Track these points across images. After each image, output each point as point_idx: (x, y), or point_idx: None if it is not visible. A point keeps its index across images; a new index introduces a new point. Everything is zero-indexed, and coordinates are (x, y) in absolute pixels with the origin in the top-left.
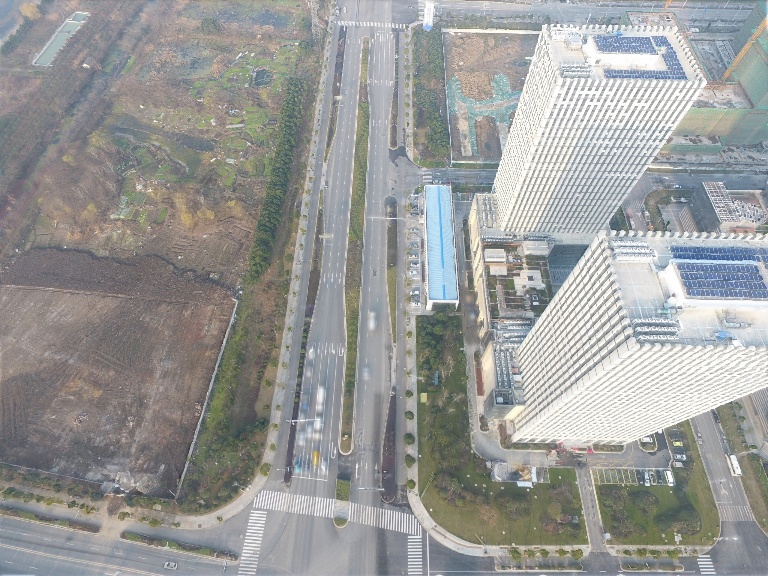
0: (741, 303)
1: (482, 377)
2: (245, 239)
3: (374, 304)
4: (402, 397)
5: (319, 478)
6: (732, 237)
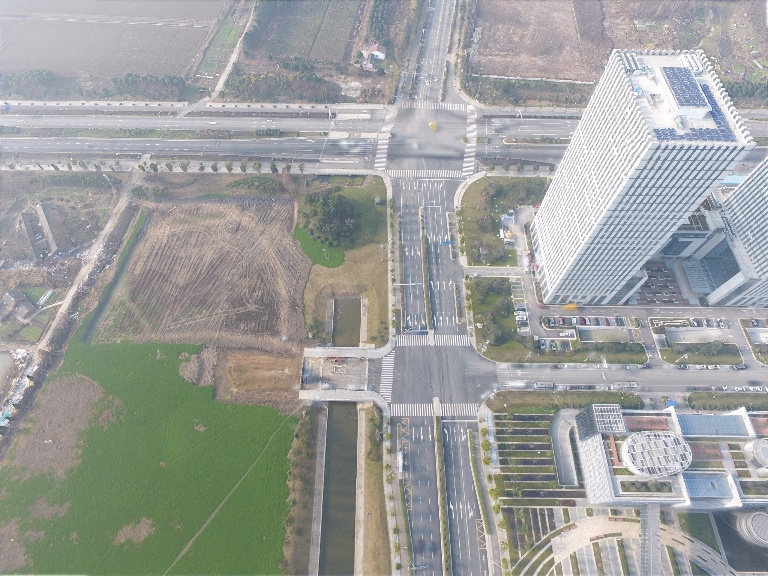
0: (668, 93)
1: None
2: None
3: None
4: (548, 169)
5: (487, 130)
6: (734, 114)
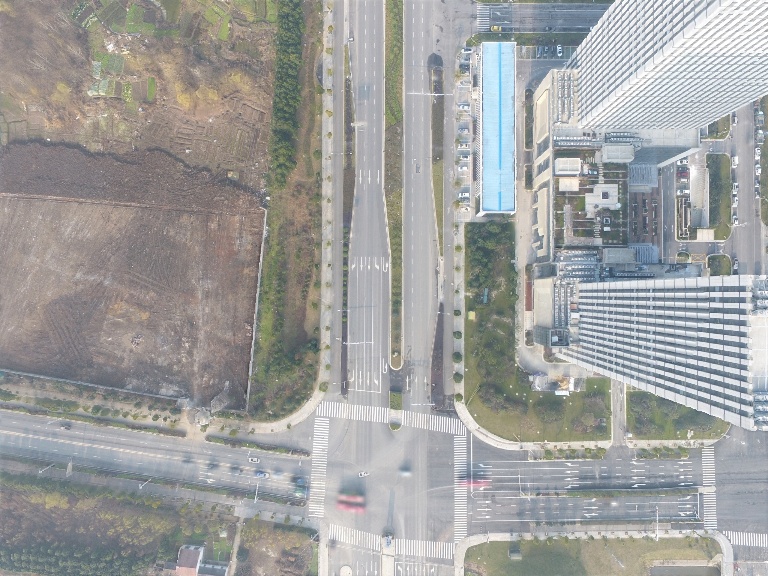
0: None
1: (532, 292)
2: (260, 123)
3: (418, 210)
4: (449, 314)
5: (373, 391)
6: None
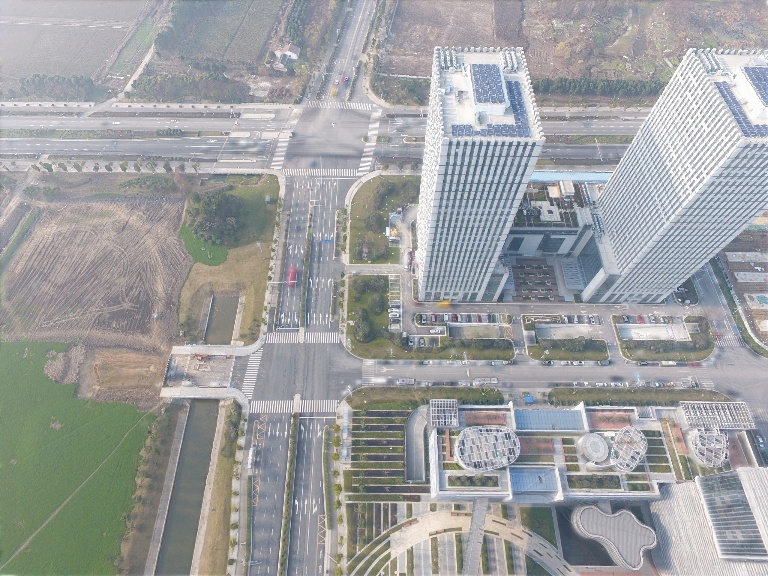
0: None
1: None
2: None
3: None
4: None
5: (389, 129)
6: None
